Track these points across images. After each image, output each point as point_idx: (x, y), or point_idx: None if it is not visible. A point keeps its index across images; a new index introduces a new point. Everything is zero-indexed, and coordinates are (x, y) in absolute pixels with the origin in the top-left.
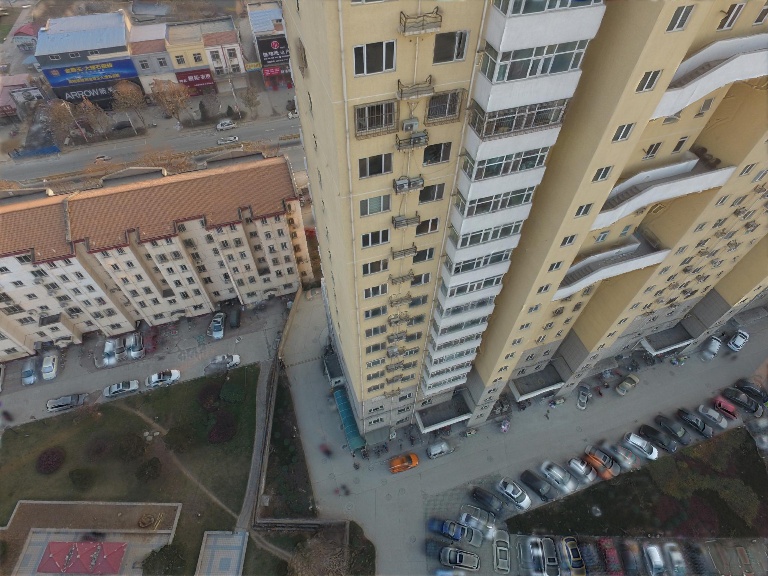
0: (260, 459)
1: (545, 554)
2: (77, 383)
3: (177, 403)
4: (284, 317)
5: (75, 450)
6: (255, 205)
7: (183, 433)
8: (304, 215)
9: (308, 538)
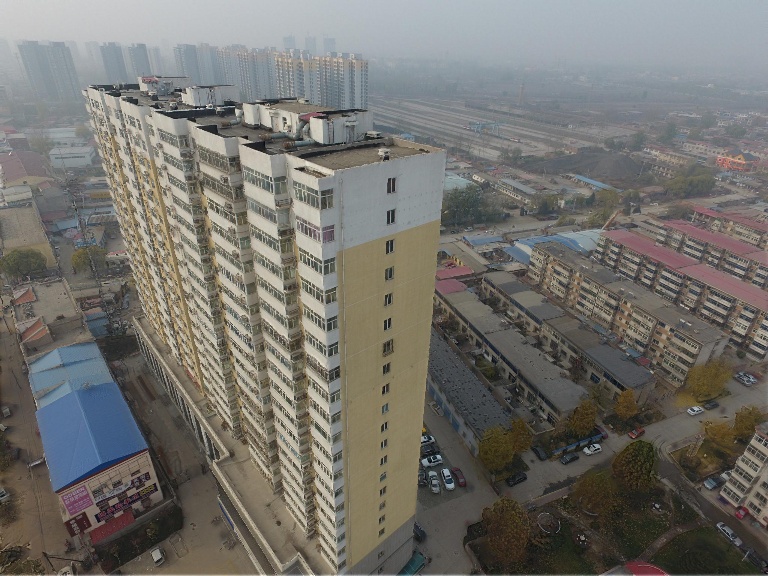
0: None
1: (424, 441)
2: None
3: None
4: None
5: None
6: None
7: None
8: None
9: (489, 571)
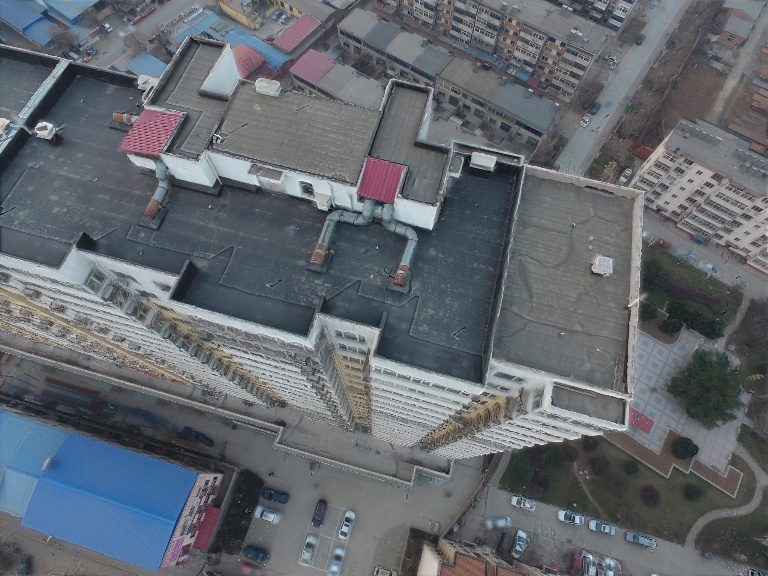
0: None
1: None
2: (635, 558)
3: (564, 490)
4: (464, 520)
5: (635, 495)
6: (480, 575)
7: (566, 452)
8: None
9: None
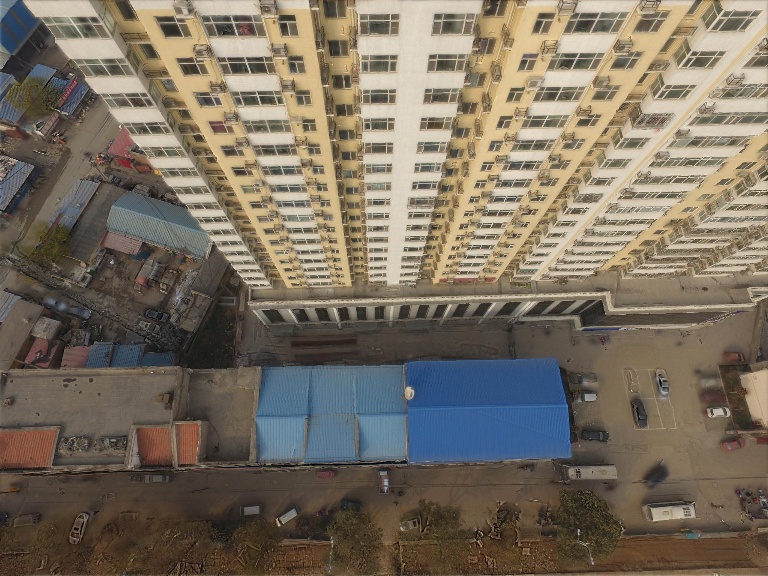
0: None
1: None
2: None
3: None
4: None
5: None
6: None
7: None
8: (756, 475)
9: None
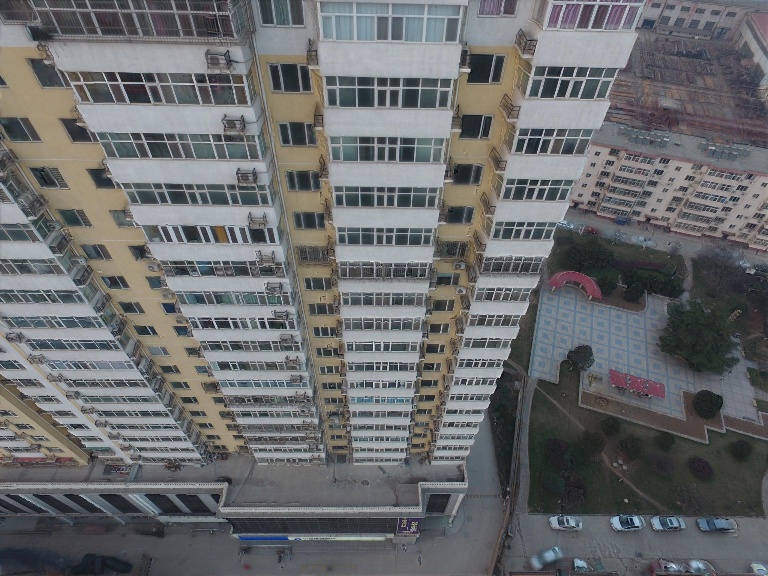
0: (523, 418)
1: None
2: (721, 551)
3: (605, 491)
4: (503, 569)
5: (684, 473)
6: None
7: (590, 440)
8: None
9: None
